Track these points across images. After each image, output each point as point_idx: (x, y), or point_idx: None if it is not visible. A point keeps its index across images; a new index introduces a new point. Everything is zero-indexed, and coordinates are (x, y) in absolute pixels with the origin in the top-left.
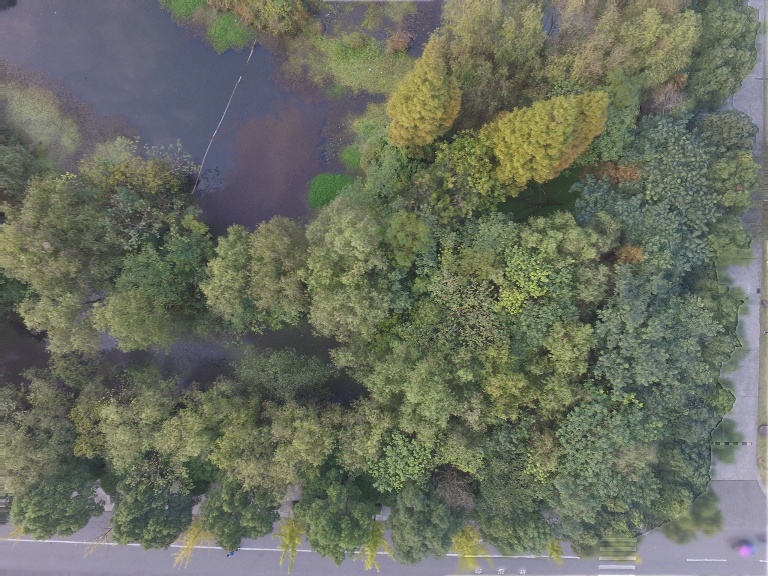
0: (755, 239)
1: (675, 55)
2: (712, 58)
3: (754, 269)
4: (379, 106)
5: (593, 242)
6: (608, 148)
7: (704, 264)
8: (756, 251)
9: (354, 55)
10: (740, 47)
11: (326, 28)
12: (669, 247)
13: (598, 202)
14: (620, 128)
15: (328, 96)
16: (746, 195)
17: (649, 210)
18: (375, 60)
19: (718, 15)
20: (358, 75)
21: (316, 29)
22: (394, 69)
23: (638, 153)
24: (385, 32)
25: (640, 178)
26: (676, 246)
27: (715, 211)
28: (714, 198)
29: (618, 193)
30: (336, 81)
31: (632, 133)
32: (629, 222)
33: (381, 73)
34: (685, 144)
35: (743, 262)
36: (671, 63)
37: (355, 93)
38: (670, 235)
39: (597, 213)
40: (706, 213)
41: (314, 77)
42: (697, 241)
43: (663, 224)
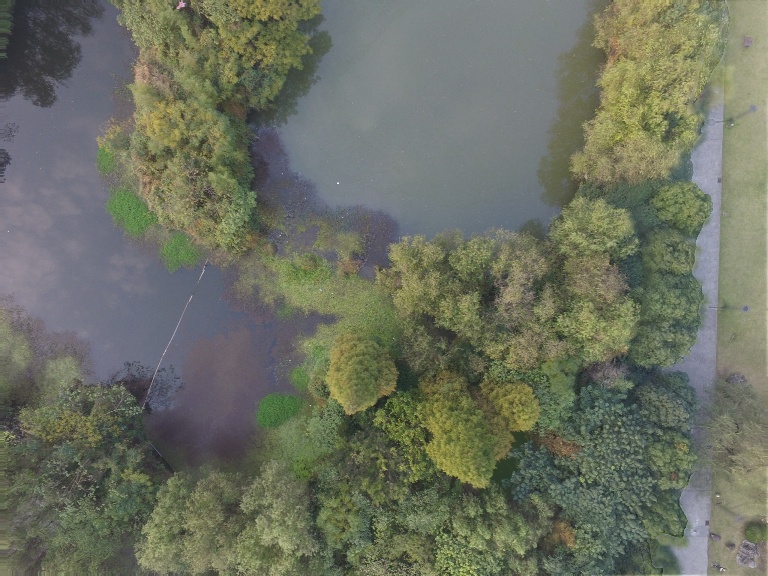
0: (705, 470)
1: (612, 340)
2: (650, 340)
3: (703, 501)
4: (329, 327)
5: (522, 536)
6: (544, 425)
7: (638, 544)
8: (705, 483)
9: (305, 276)
10: (680, 328)
11: (277, 249)
12: (601, 536)
13: (533, 478)
14: (556, 408)
15: (279, 316)
16: (681, 484)
17: (583, 492)
18: (326, 281)
19: (657, 298)
20: (309, 296)
21: (267, 251)
22: (345, 290)
23: (574, 431)
24: (336, 254)
25: (574, 461)
26: (609, 531)
27: (650, 494)
28: (649, 481)
29: (553, 470)
30: (287, 302)
31: (568, 411)
32: (562, 506)
33: (332, 294)
34: (620, 432)
35: (692, 494)
36: (608, 347)
37: (305, 314)
38: (604, 518)
39: (530, 494)
40: (641, 496)
41: (265, 297)
42: (631, 525)
43: (597, 508)
